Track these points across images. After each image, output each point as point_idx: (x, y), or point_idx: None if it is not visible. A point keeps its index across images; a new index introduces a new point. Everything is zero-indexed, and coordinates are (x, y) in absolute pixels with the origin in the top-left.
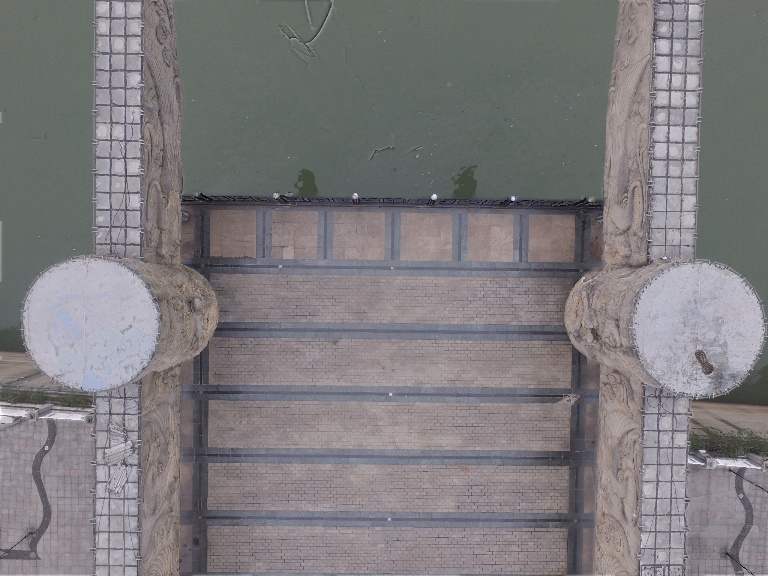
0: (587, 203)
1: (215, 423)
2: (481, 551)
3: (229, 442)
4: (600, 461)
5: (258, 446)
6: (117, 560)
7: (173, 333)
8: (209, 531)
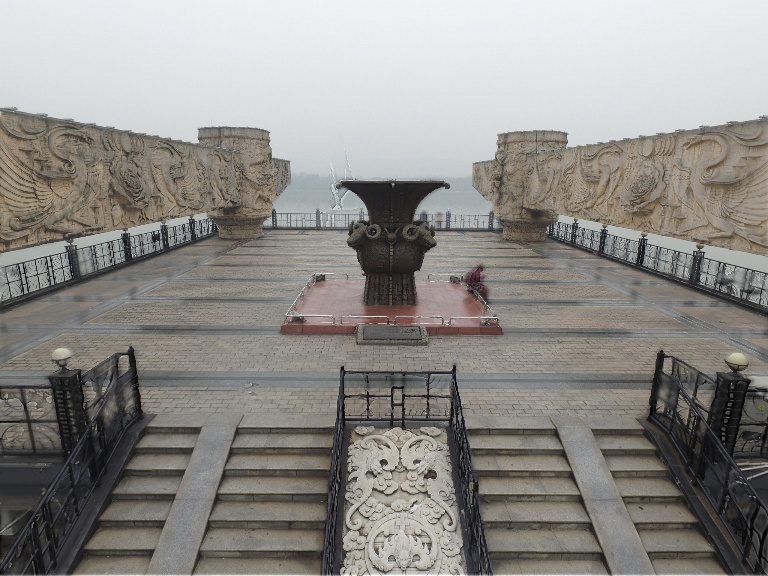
0: (493, 218)
1: None
2: (489, 274)
3: None
4: (546, 206)
5: None
6: None
7: (267, 148)
8: None
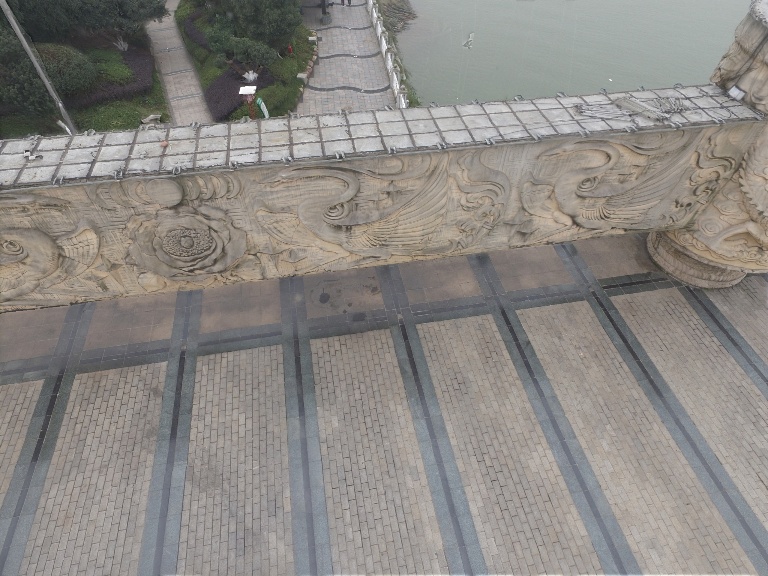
0: None
1: (557, 313)
2: None
3: (537, 337)
4: None
5: (553, 381)
6: (473, 122)
7: None
8: (381, 332)
